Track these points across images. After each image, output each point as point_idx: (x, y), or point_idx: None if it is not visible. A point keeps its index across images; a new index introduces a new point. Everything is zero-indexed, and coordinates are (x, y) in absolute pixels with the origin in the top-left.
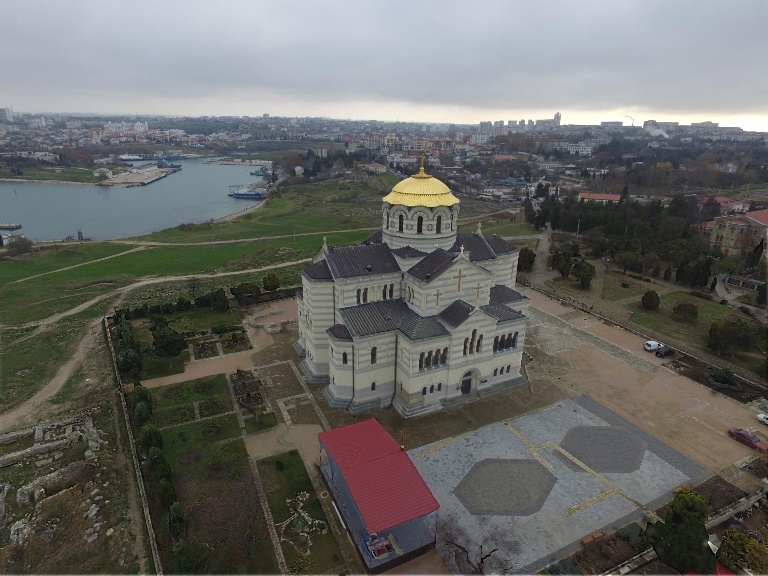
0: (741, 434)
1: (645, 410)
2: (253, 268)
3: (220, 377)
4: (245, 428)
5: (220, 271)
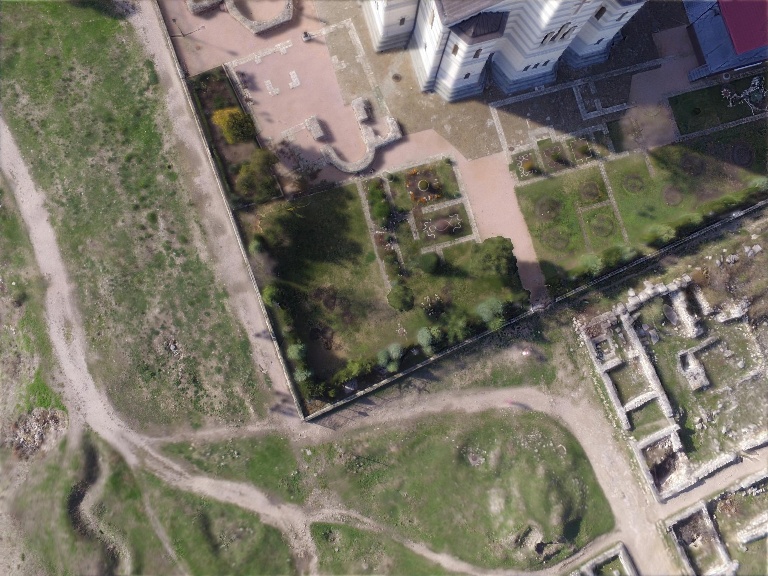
0: None
1: None
2: (8, 198)
3: (526, 192)
4: (632, 150)
5: (22, 272)
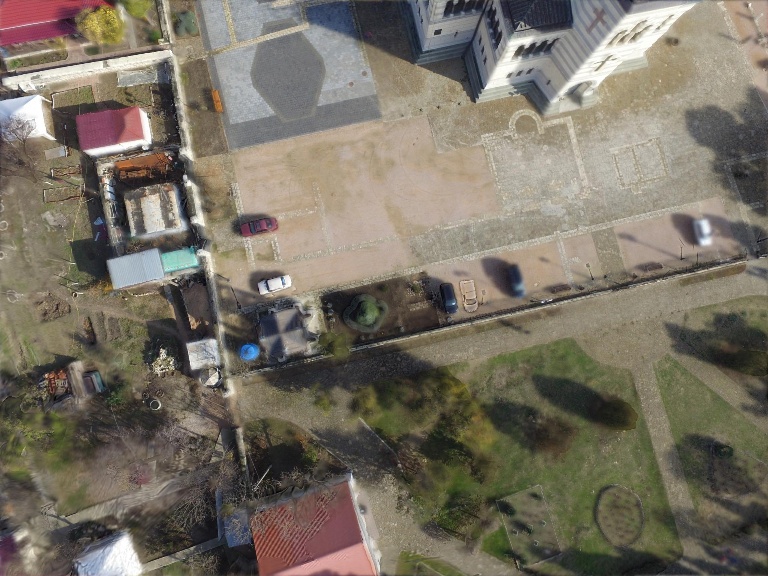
0: (262, 219)
1: (337, 166)
2: None
3: None
4: None
5: None
